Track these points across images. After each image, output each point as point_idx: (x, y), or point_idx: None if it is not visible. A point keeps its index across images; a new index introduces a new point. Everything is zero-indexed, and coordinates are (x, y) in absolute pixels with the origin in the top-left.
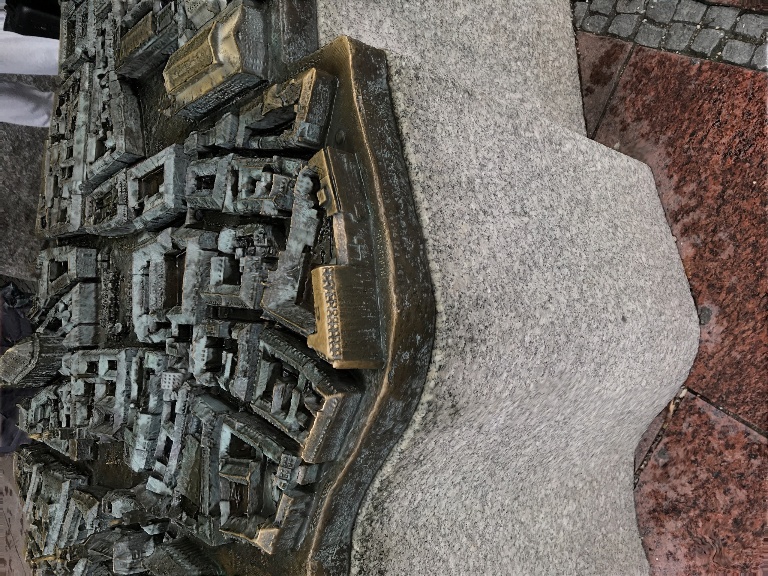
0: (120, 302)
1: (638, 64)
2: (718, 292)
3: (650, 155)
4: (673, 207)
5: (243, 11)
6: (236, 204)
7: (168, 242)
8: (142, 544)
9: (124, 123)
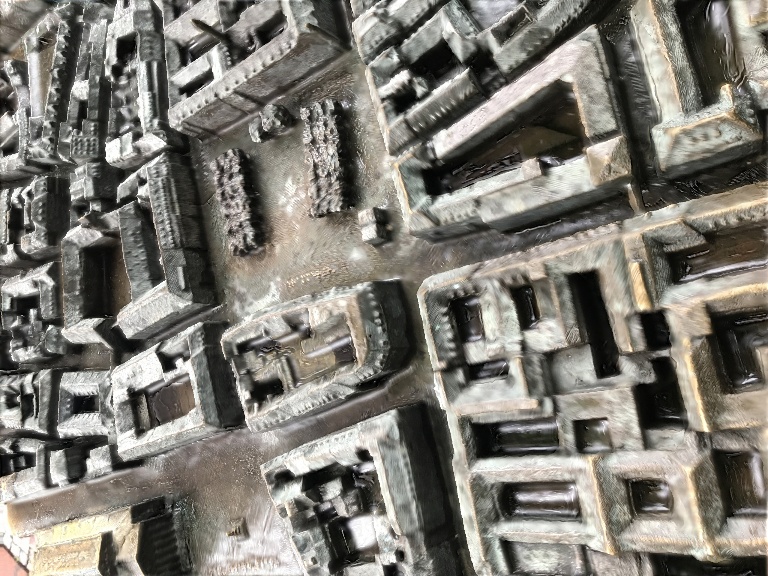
0: None
1: None
2: None
3: None
4: None
5: None
6: (37, 380)
7: None
8: None
9: None
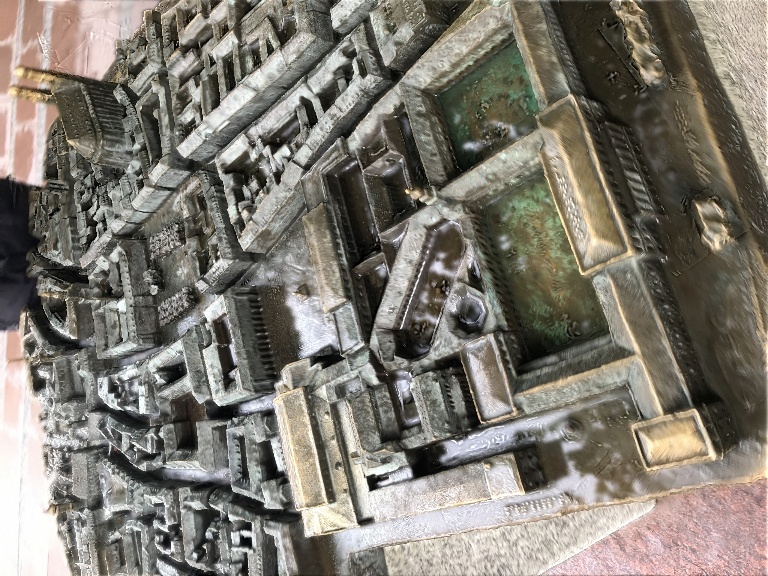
0: (174, 255)
1: (767, 488)
2: (562, 567)
3: (666, 506)
4: (621, 530)
5: (355, 527)
6: None
7: (200, 401)
8: (85, 409)
9: (267, 225)
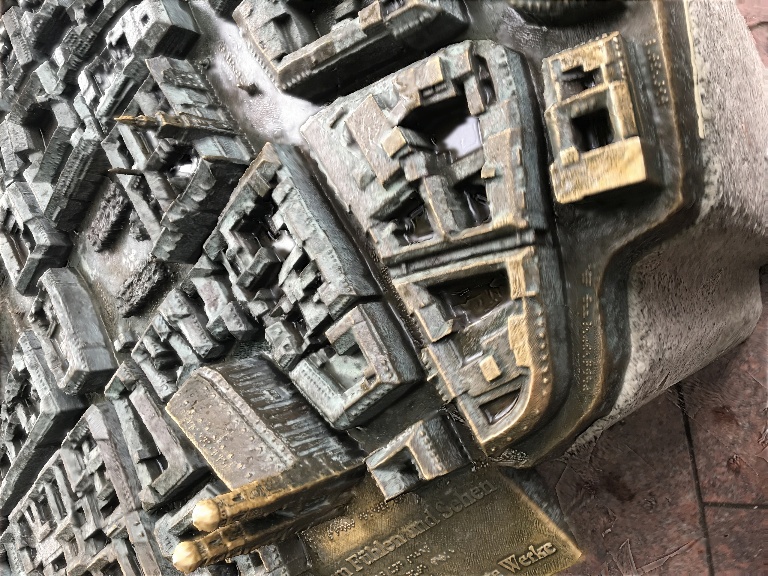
0: None
1: None
2: None
3: None
4: None
5: None
6: None
7: None
8: None
9: None
